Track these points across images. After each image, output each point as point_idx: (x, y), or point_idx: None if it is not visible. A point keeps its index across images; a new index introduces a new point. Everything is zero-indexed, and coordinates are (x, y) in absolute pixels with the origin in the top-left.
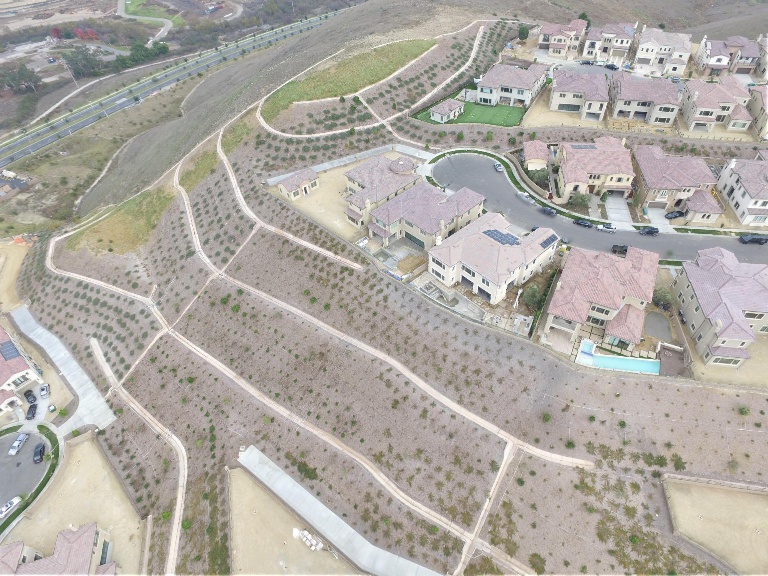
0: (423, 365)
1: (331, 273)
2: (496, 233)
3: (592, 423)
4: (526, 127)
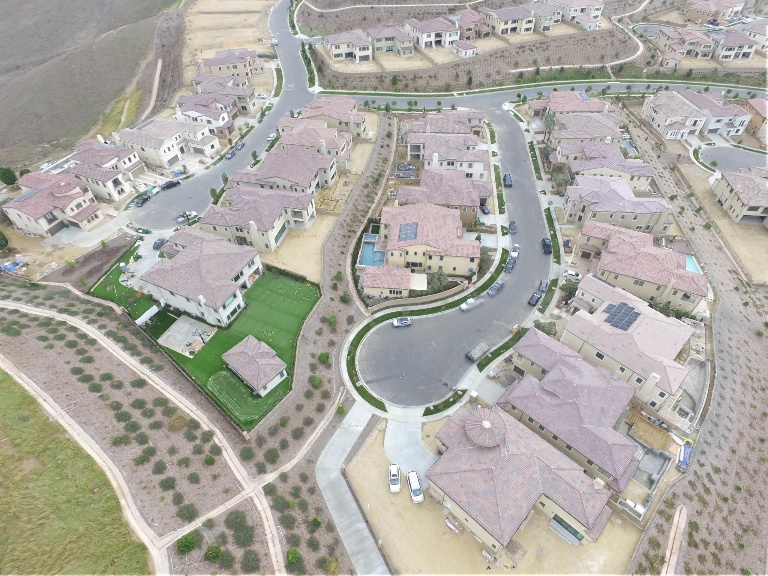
0: (767, 432)
1: (700, 567)
2: (615, 320)
3: (747, 306)
4: (316, 279)
